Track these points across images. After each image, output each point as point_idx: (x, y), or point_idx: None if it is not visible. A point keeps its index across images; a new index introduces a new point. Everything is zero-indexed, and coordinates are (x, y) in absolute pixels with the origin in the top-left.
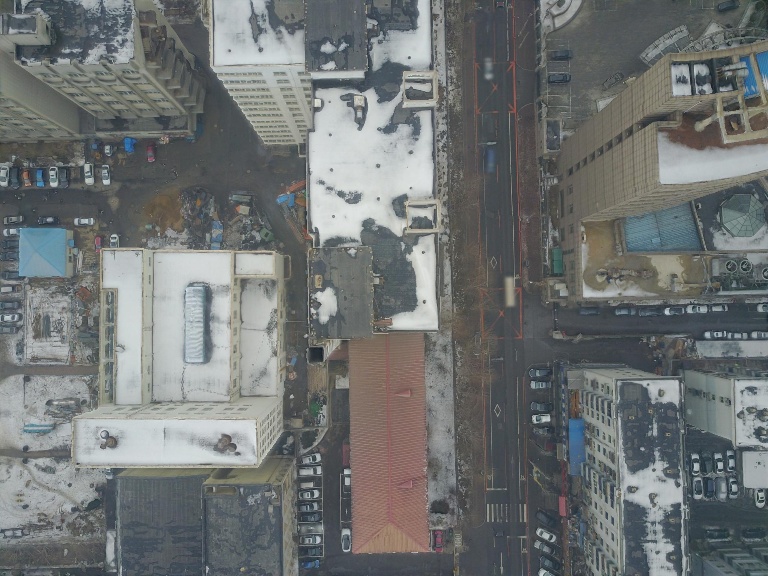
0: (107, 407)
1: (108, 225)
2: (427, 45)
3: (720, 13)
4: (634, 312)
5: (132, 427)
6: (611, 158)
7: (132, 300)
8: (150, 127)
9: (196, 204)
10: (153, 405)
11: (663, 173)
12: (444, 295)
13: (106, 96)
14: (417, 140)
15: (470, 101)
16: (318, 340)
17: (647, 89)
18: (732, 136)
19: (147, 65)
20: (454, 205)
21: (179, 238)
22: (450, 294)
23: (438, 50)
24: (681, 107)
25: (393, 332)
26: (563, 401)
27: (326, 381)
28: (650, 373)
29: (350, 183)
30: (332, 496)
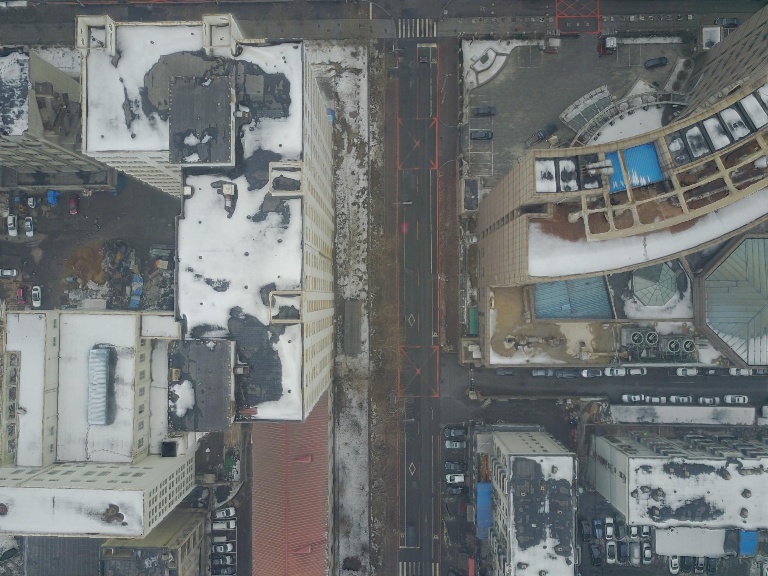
0: (8, 468)
1: (31, 276)
2: (298, 133)
3: (647, 70)
4: (551, 373)
5: (22, 495)
6: (503, 236)
7: (35, 362)
8: (71, 181)
9: (116, 258)
10: (54, 467)
11: (534, 265)
12: (361, 352)
13: (18, 156)
14: (286, 228)
15: (392, 157)
16: (176, 432)
17: (521, 179)
18: (595, 235)
19: (45, 134)
20: (373, 262)
21: (100, 290)
22: (367, 351)
23: (360, 105)
24: (551, 200)
25: (257, 421)
26: (473, 464)
27: (241, 436)
28: (554, 443)
29: (219, 271)
30: (246, 550)
